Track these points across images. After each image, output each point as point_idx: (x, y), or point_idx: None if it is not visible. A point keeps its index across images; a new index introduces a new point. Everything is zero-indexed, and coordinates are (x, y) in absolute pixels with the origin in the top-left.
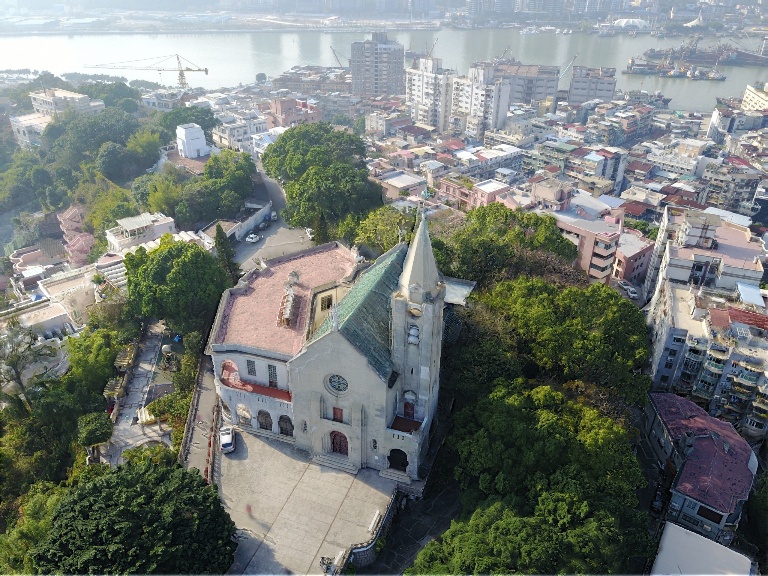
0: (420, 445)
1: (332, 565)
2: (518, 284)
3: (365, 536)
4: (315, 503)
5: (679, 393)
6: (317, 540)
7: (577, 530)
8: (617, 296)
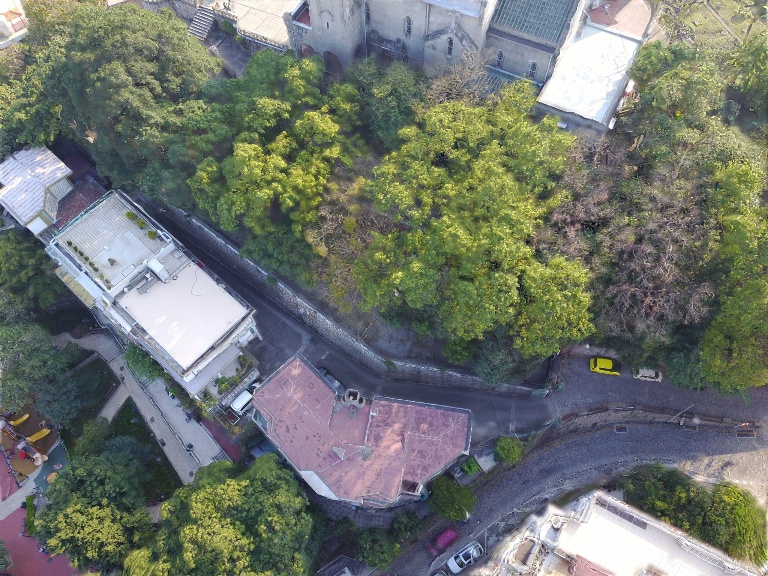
0: (293, 35)
1: (227, 10)
2: (551, 138)
3: (247, 29)
4: (287, 2)
5: (527, 530)
6: (253, 4)
7: (115, 67)
8: (494, 251)
